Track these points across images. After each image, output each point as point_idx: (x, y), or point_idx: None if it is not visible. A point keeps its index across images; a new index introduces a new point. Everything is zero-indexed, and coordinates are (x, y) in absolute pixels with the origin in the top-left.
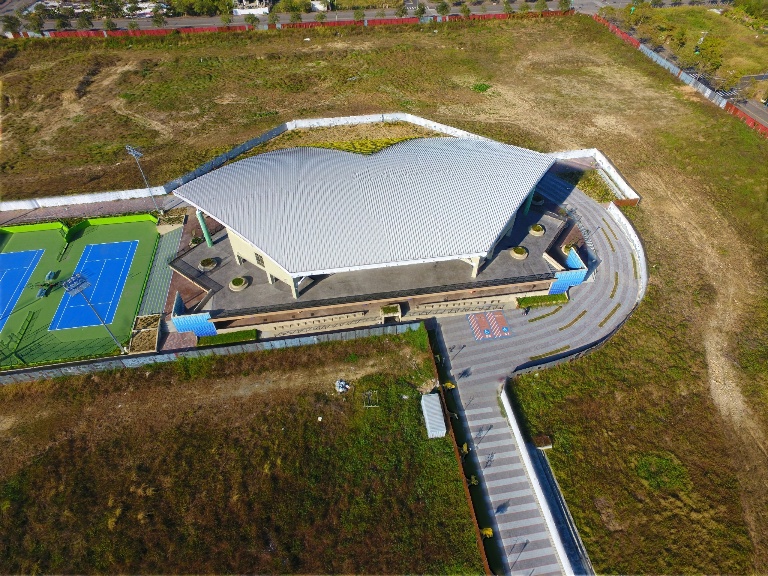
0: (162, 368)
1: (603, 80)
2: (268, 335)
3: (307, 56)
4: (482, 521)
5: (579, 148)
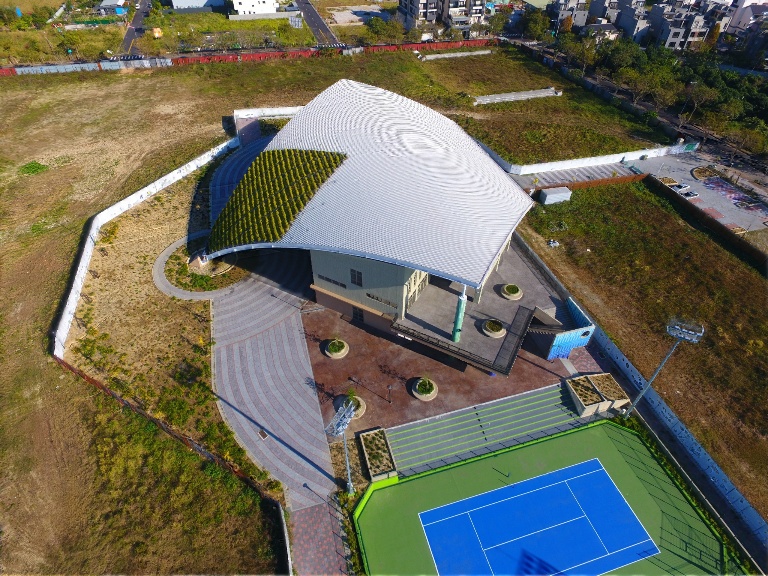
0: (623, 360)
1: (73, 101)
2: None
3: None
4: None
5: (215, 125)
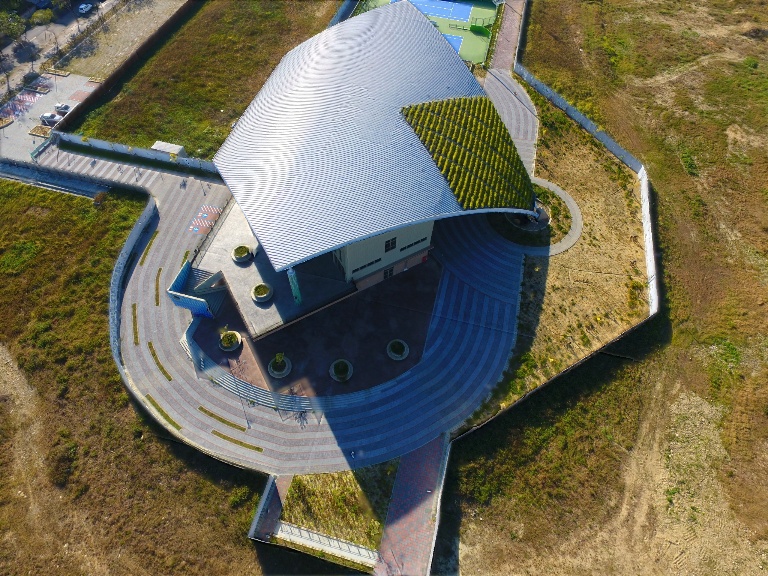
0: None
1: None
2: None
3: None
4: (98, 152)
5: None
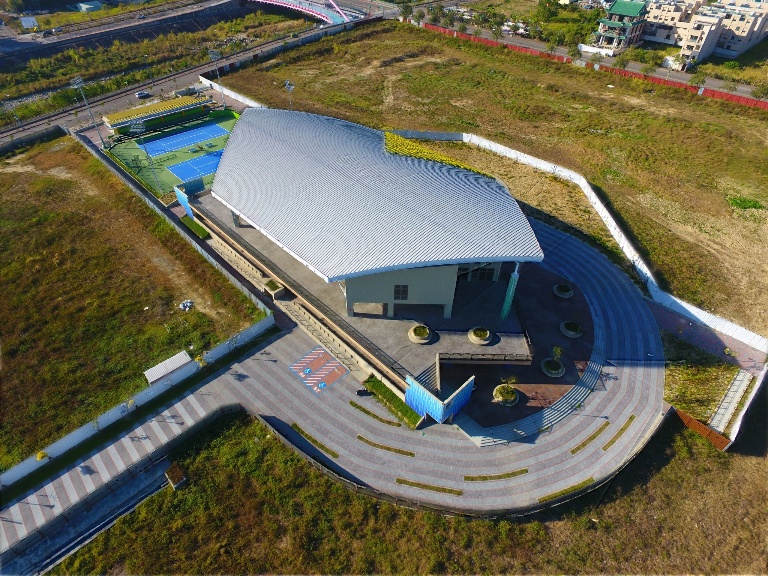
0: (154, 216)
1: None
2: (211, 243)
3: (585, 98)
4: (68, 458)
5: None
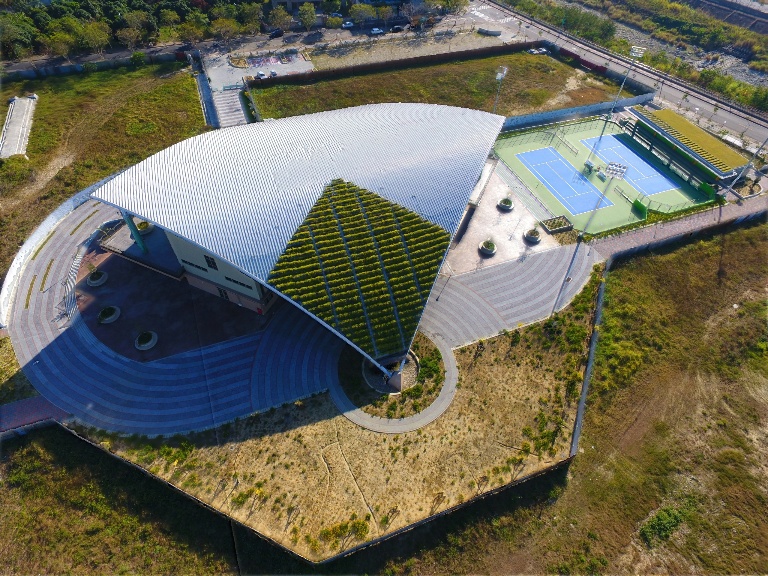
0: None
1: None
2: None
3: None
4: (249, 106)
5: None
